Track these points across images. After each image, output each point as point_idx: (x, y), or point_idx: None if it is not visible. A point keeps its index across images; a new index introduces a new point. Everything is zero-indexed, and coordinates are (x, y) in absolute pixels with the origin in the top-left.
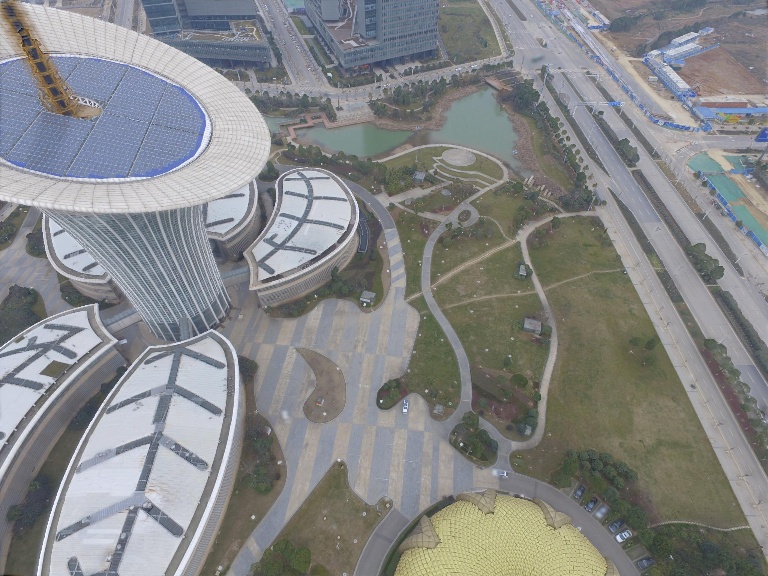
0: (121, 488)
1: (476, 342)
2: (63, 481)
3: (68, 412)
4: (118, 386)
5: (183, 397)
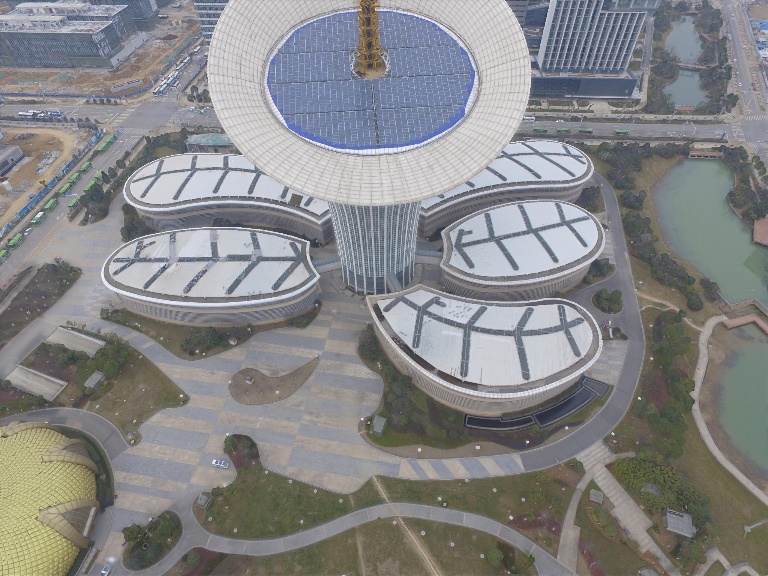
0: (185, 250)
1: (289, 573)
2: (210, 227)
3: (283, 223)
4: (275, 234)
5: (247, 267)
